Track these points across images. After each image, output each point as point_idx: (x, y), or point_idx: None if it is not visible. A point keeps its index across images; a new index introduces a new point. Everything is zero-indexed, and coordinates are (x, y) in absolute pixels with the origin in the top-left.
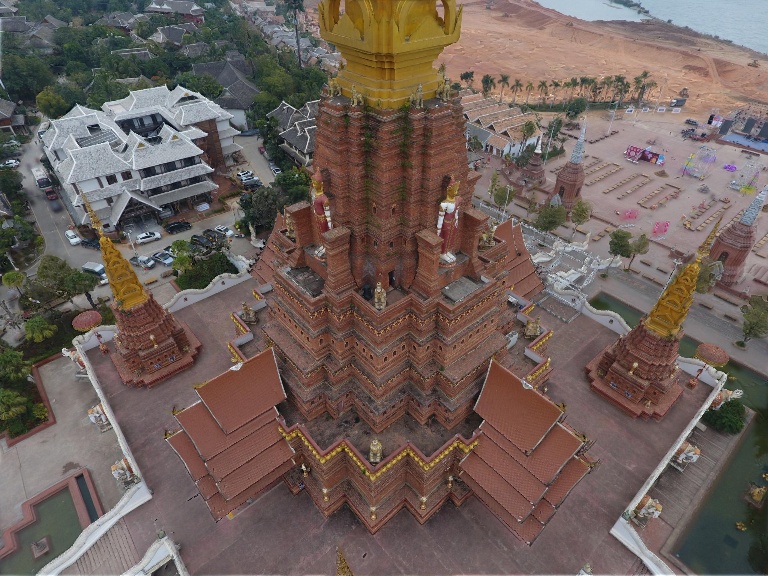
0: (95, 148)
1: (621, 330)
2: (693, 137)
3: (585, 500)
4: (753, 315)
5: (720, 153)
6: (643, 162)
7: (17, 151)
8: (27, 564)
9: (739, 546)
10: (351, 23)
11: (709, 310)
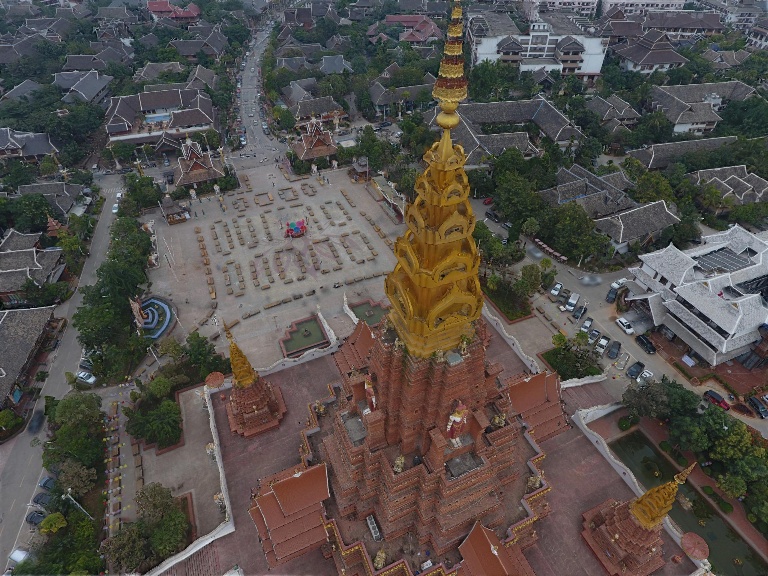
0: (685, 257)
1: None
2: None
3: (267, 567)
4: None
5: None
6: None
7: (765, 227)
8: (364, 311)
9: None
10: None
11: None
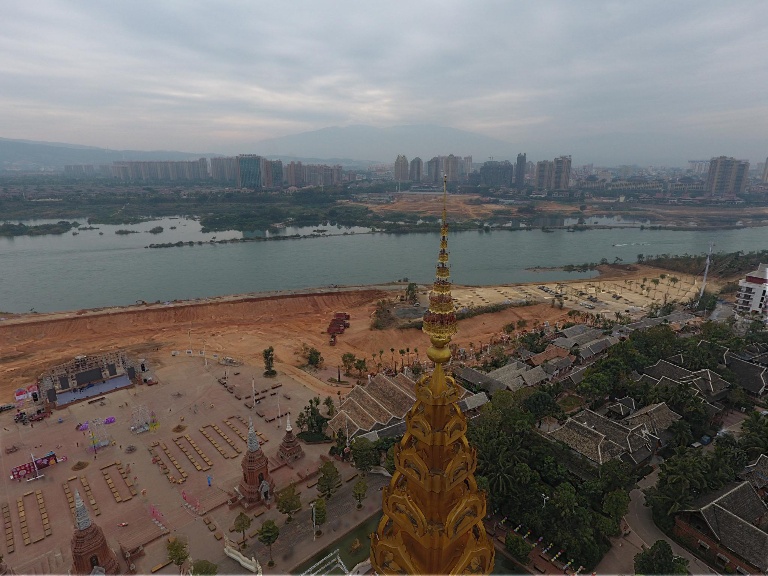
0: None
1: (365, 569)
2: (35, 419)
3: None
4: (359, 488)
5: (79, 415)
6: (44, 471)
7: None
8: None
9: (503, 571)
10: (475, 574)
11: (302, 510)
